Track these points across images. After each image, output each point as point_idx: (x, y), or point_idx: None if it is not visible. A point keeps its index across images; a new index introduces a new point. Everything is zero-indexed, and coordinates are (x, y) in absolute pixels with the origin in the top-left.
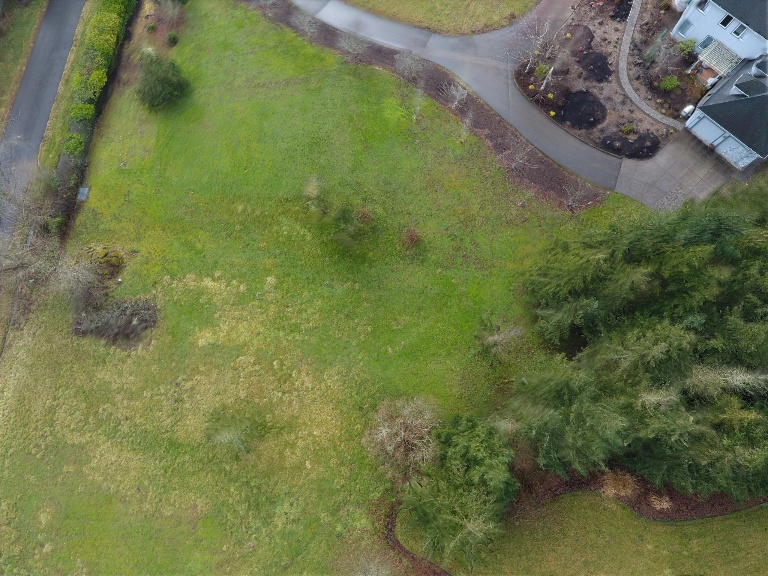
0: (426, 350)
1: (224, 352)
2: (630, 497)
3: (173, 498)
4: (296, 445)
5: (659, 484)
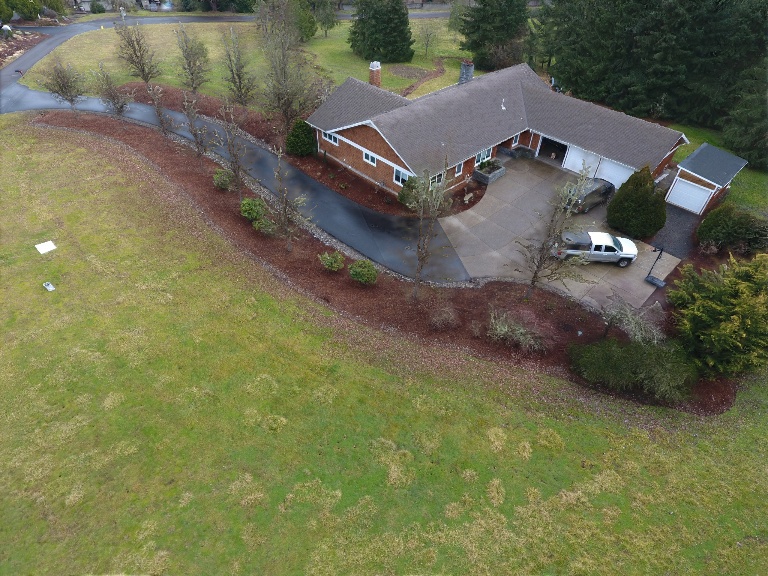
0: None
1: None
2: None
3: (412, 37)
4: None
5: None
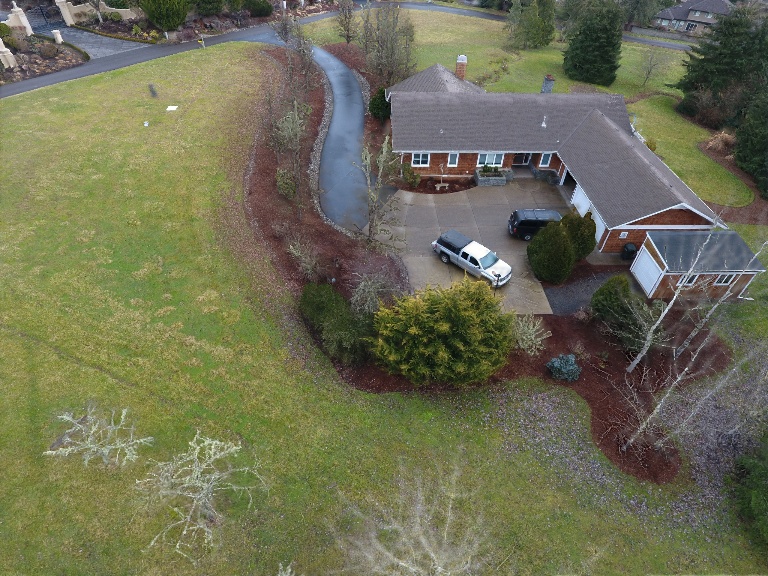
0: None
1: None
2: None
3: None
4: None
5: None
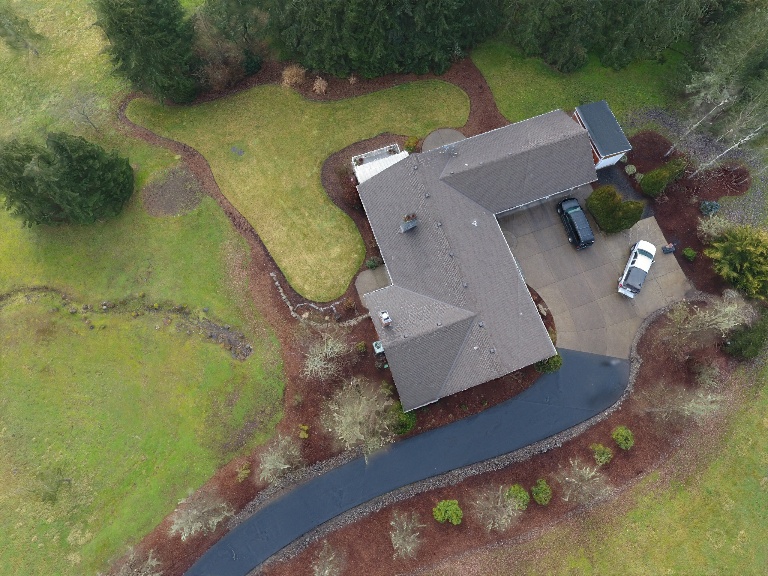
0: (181, 3)
1: (31, 6)
2: (302, 87)
3: None
4: (69, 62)
5: (313, 63)
